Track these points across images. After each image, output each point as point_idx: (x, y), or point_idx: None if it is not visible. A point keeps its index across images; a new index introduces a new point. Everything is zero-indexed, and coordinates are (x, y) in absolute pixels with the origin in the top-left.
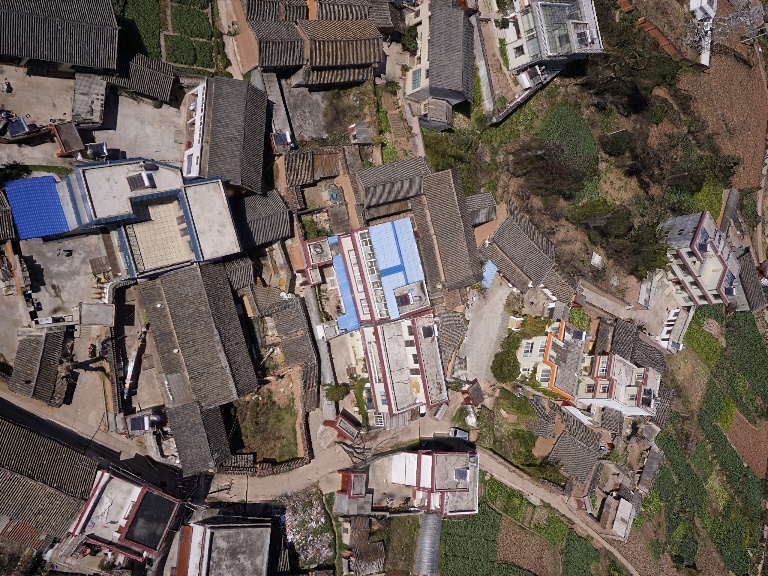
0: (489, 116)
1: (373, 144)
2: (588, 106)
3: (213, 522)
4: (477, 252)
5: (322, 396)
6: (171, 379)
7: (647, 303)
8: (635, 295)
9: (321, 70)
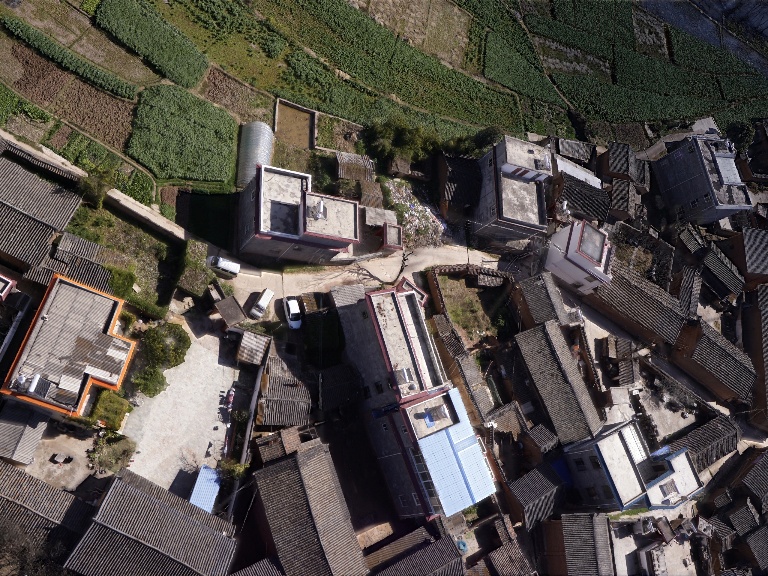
0: None
1: None
2: None
3: (515, 236)
4: (269, 512)
5: None
6: None
7: None
8: None
9: None
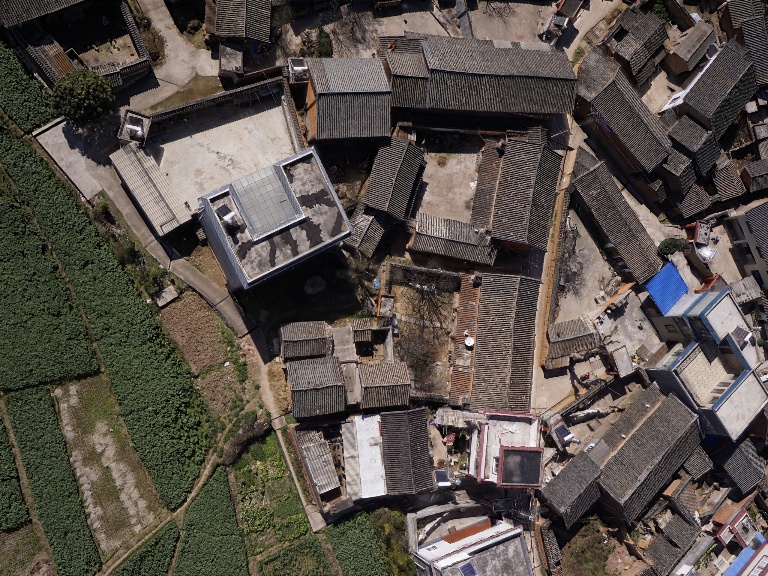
0: None
1: None
2: None
3: None
4: None
5: None
6: (601, 444)
7: None
8: None
9: None
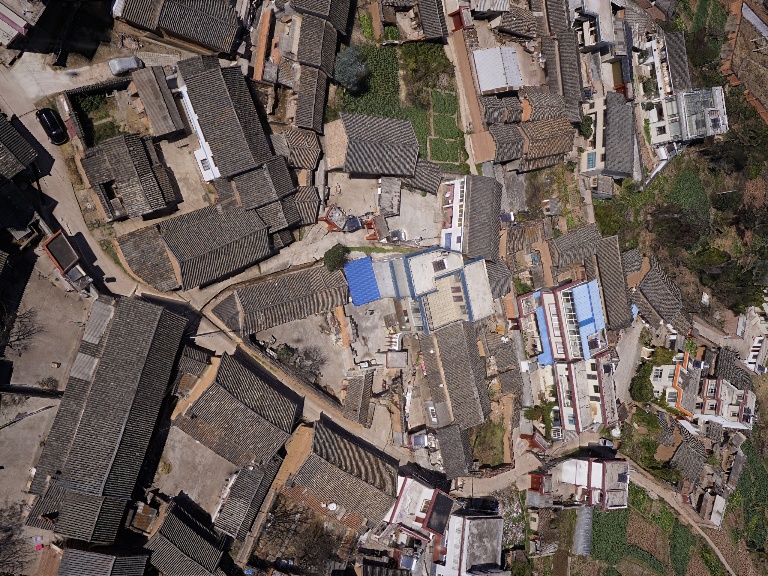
0: (637, 185)
1: (561, 215)
2: (704, 169)
3: (460, 513)
4: None
5: (520, 415)
6: (437, 406)
7: (743, 334)
8: (733, 327)
9: (531, 160)
